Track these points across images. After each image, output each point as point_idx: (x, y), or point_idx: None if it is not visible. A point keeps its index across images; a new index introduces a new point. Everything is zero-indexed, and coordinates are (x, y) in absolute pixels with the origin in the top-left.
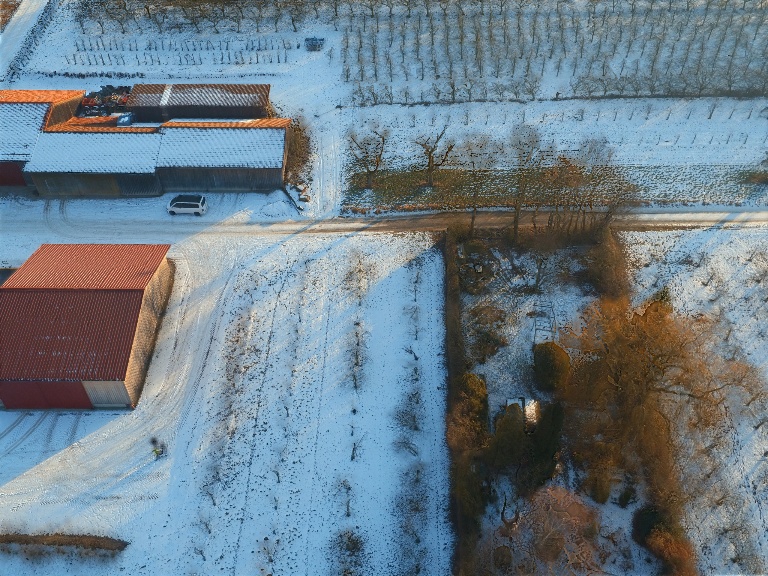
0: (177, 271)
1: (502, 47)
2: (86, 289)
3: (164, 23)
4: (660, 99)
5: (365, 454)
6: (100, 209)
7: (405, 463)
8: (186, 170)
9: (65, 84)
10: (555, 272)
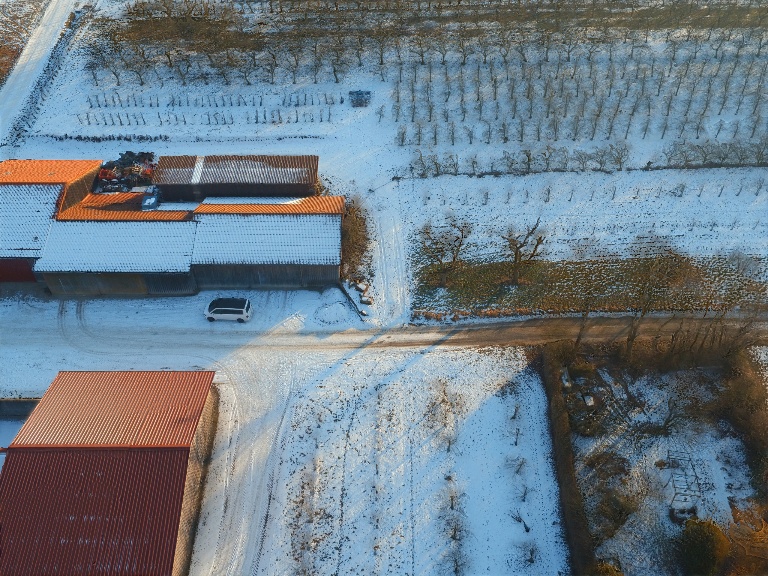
0: (221, 400)
1: (577, 104)
2: (117, 448)
3: (188, 74)
4: (767, 168)
5: None
6: (124, 313)
7: None
8: (226, 266)
9: (78, 149)
10: (681, 403)
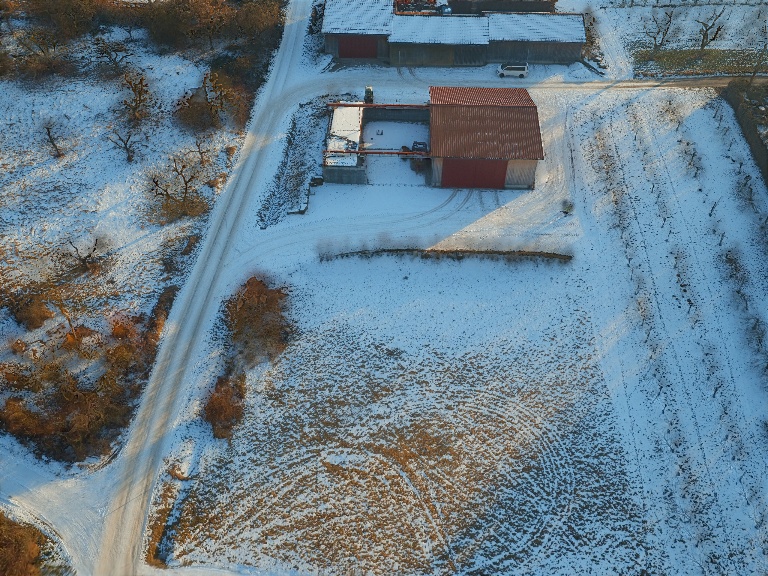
0: None
1: None
2: (494, 105)
3: None
4: None
5: (718, 213)
6: (442, 73)
7: (750, 218)
8: (509, 44)
9: None
10: None
